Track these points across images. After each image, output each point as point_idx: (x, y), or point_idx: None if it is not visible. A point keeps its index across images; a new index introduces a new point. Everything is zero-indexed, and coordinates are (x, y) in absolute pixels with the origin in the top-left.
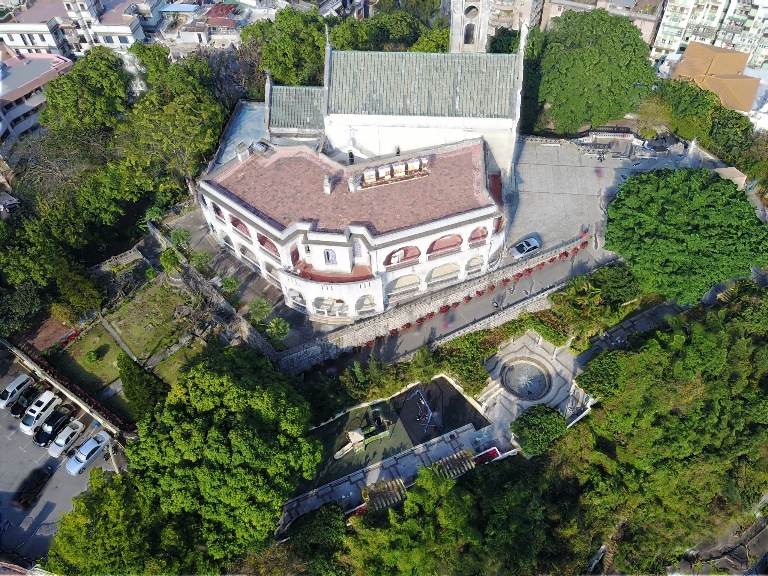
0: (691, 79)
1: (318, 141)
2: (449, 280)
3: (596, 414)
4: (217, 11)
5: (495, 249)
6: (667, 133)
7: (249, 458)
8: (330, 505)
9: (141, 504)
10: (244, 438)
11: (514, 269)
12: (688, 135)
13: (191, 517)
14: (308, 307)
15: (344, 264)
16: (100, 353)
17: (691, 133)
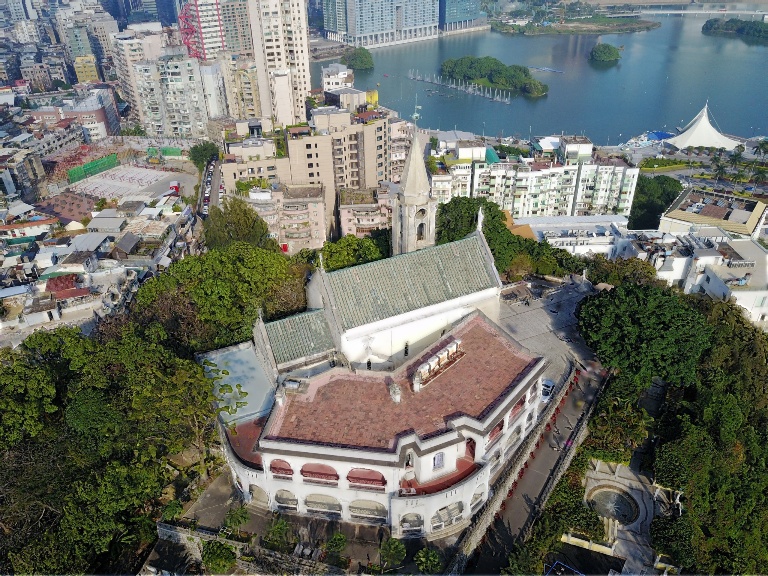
0: None
1: (341, 360)
2: (515, 443)
3: (687, 505)
4: (57, 284)
5: (540, 398)
6: (527, 275)
7: None
8: None
9: None
10: None
11: (551, 412)
12: (547, 271)
13: None
14: (425, 527)
15: (451, 463)
16: None
17: (548, 269)
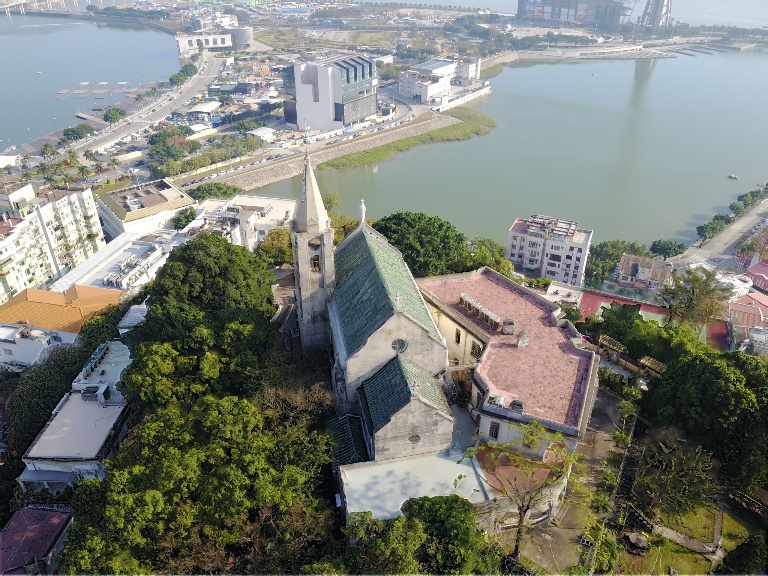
0: (130, 288)
1: (459, 368)
2: None
3: None
4: None
5: None
6: None
7: None
8: None
9: None
10: None
11: None
12: None
13: None
14: None
15: None
16: None
17: None
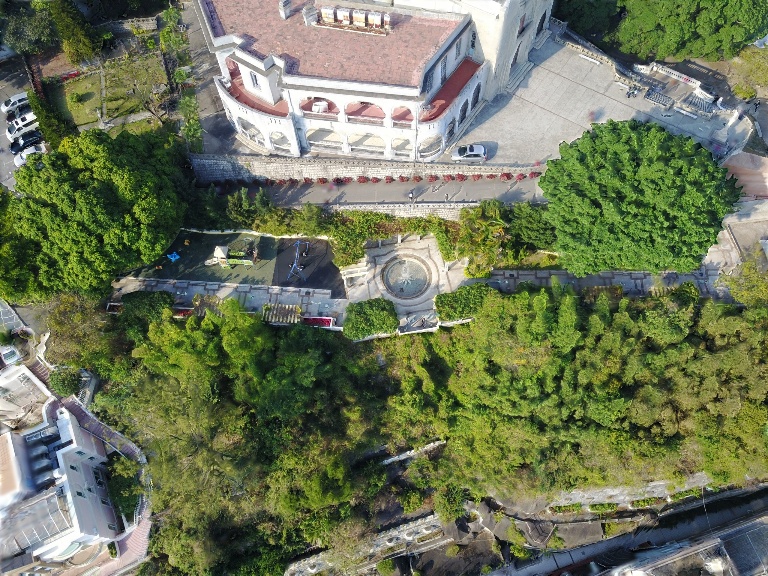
0: None
1: None
2: (375, 152)
3: (440, 335)
4: None
5: (423, 138)
6: (767, 100)
7: (86, 219)
8: (164, 293)
9: (6, 218)
10: (87, 201)
11: (445, 169)
12: None
13: (32, 244)
14: (235, 124)
15: (267, 93)
16: (84, 98)
17: None
